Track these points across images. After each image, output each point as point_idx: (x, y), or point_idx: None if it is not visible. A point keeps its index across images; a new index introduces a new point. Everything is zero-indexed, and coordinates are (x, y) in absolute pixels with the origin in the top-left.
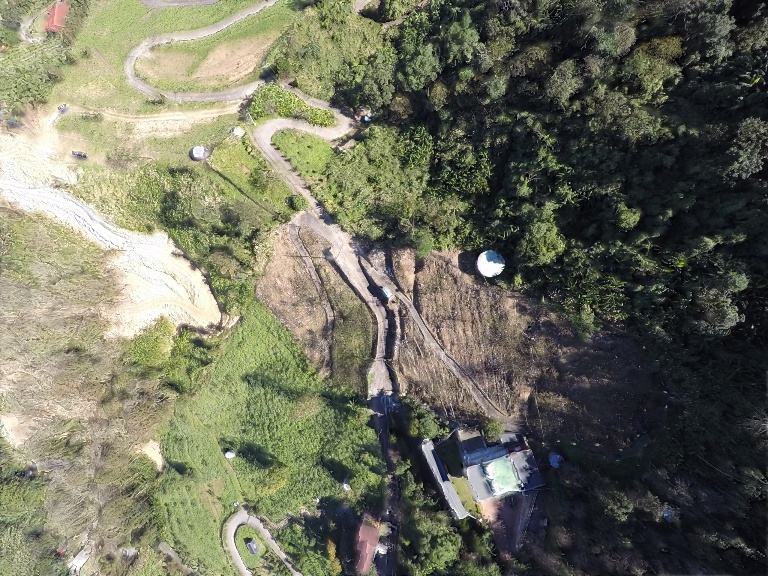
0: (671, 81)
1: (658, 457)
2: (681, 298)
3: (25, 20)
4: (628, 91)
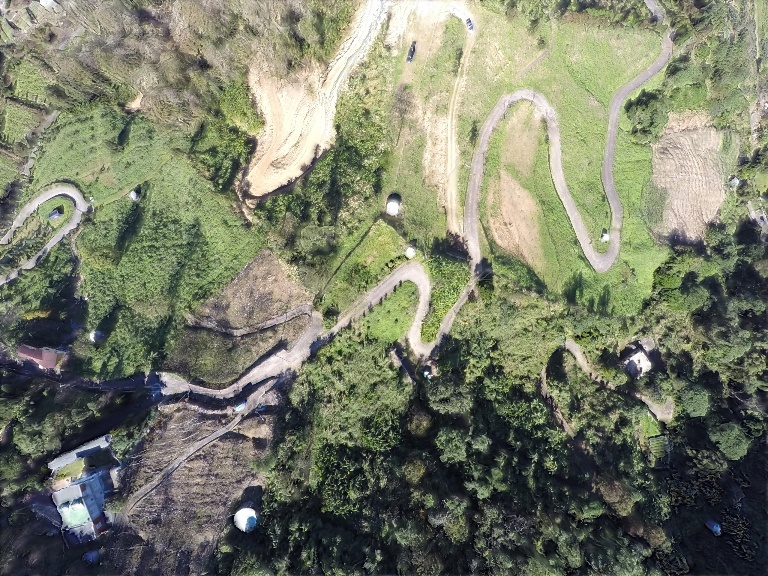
0: None
1: None
2: None
3: None
4: None
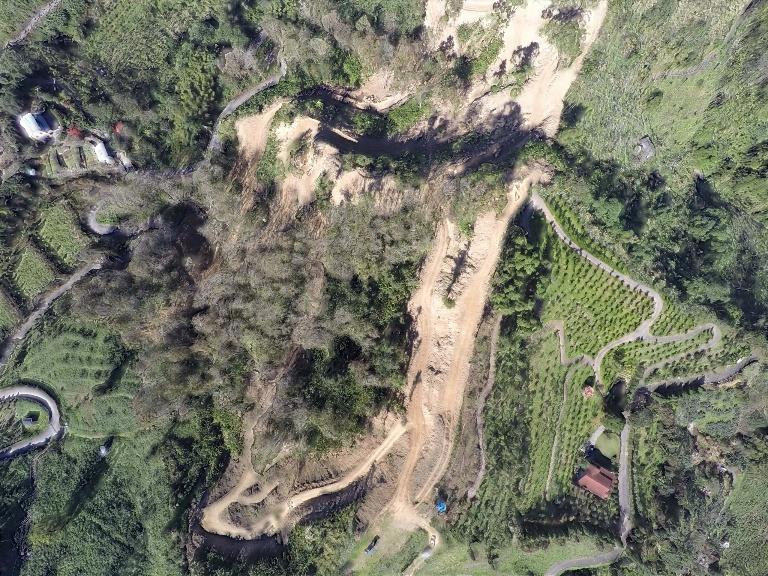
0: None
1: None
2: None
3: None
4: None
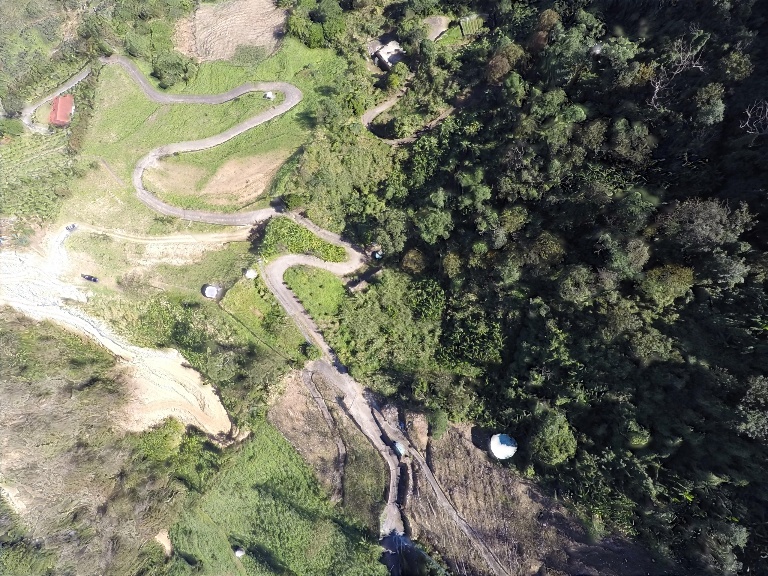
0: (682, 301)
1: None
2: (690, 529)
3: (26, 109)
4: (640, 299)
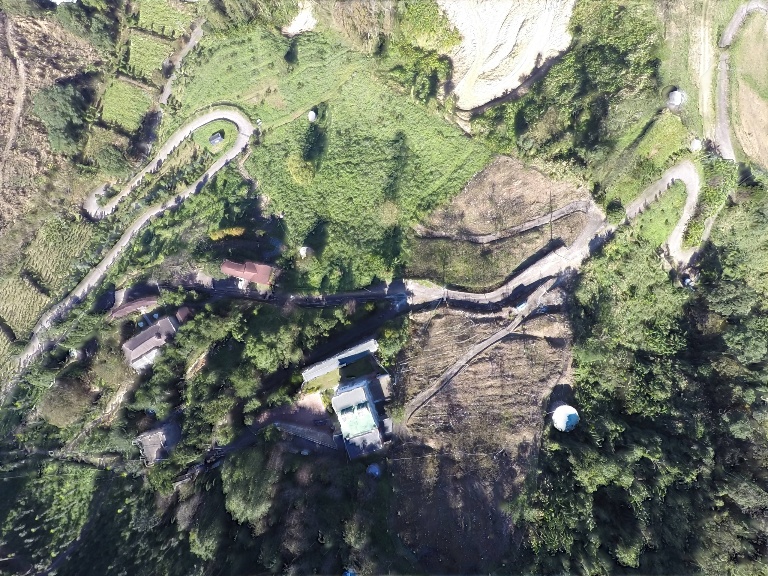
0: None
1: (398, 569)
2: None
3: None
4: (741, 558)
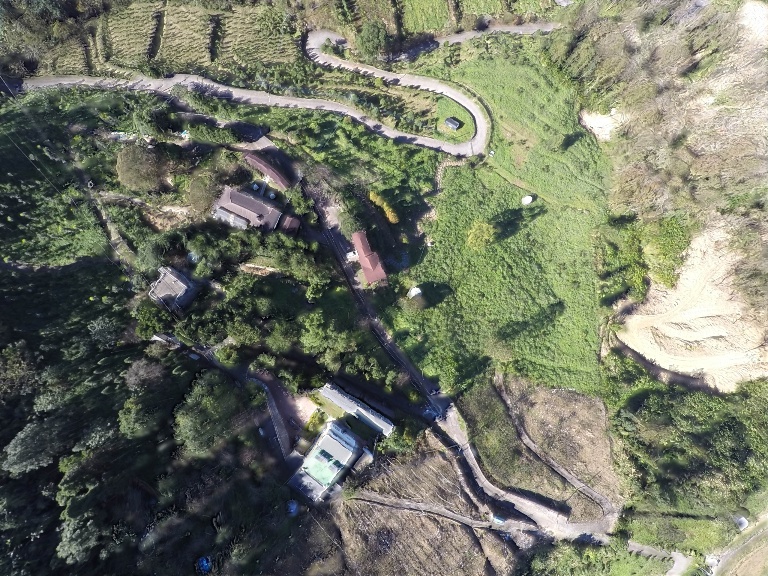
0: None
1: None
2: None
3: None
4: None
